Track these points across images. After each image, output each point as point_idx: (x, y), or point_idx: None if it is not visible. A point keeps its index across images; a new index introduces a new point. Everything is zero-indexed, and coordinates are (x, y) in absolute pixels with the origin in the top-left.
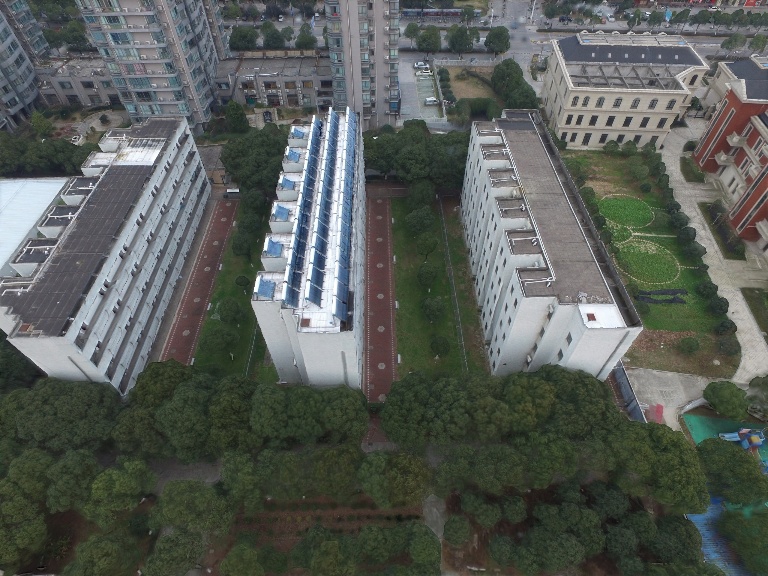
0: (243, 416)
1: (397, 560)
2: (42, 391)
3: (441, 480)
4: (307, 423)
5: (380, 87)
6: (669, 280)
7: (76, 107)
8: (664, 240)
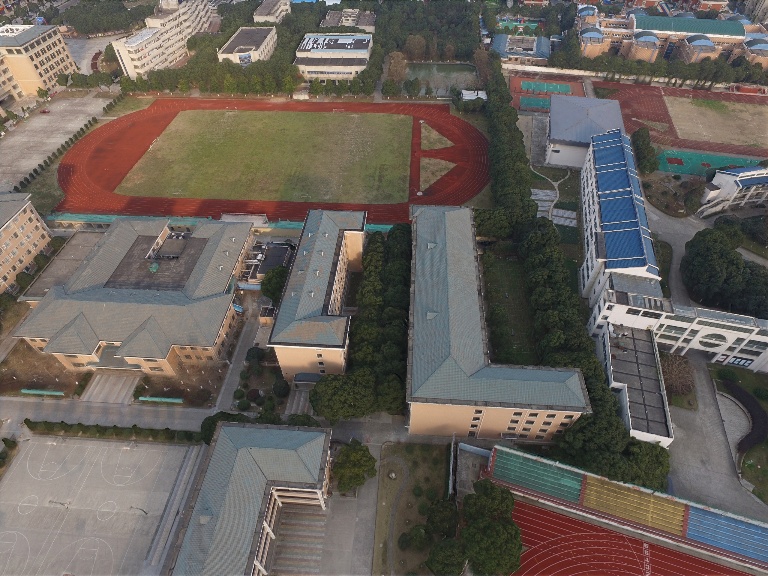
0: (404, 2)
1: None
2: None
3: None
4: (415, 3)
5: None
6: (496, 7)
7: None
8: (499, 3)
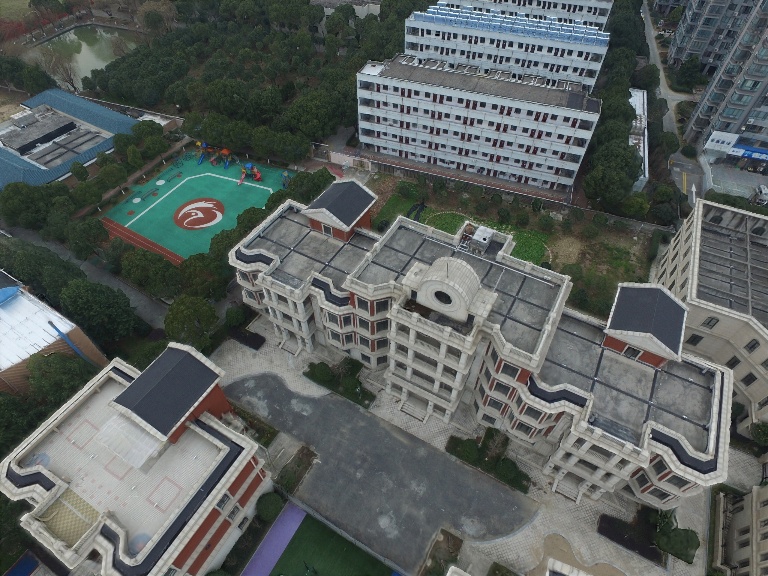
0: None
1: None
2: None
3: None
4: None
5: None
6: None
7: None
8: None
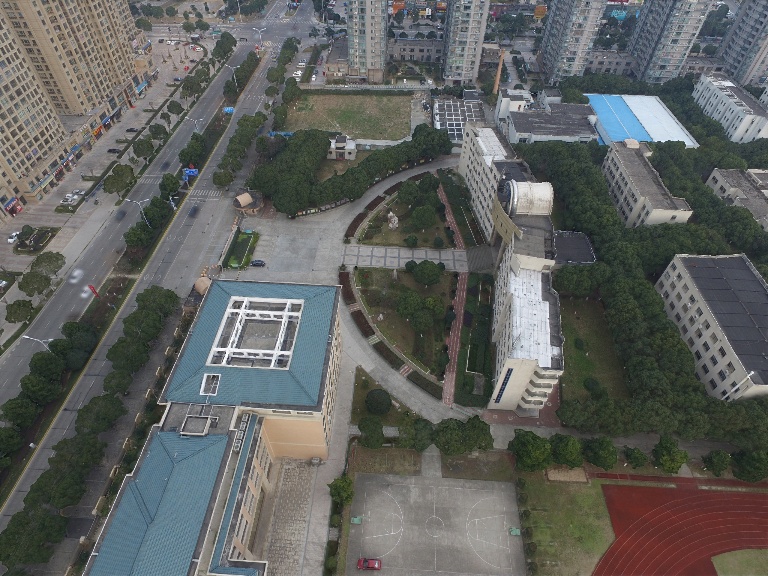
0: None
1: None
2: None
3: None
4: None
5: (761, 70)
6: None
7: (591, 73)
8: None
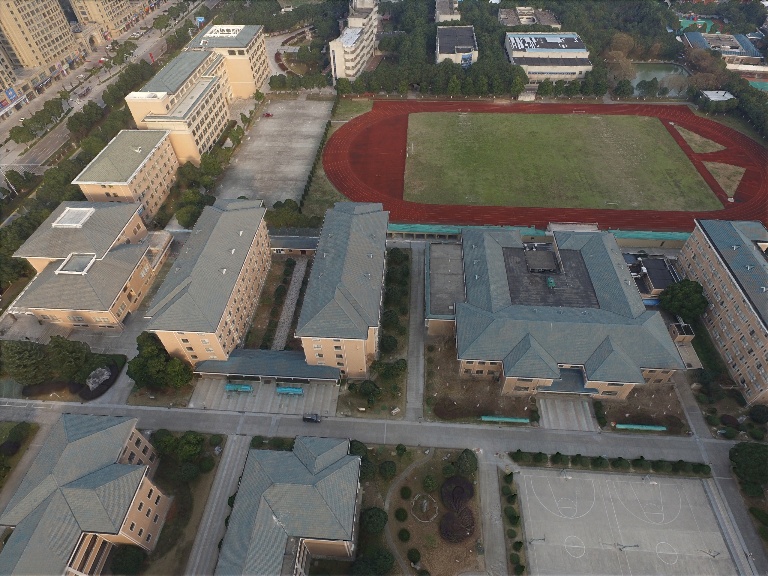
0: None
1: None
2: None
3: (609, 8)
4: None
5: None
6: None
7: None
8: (655, 0)
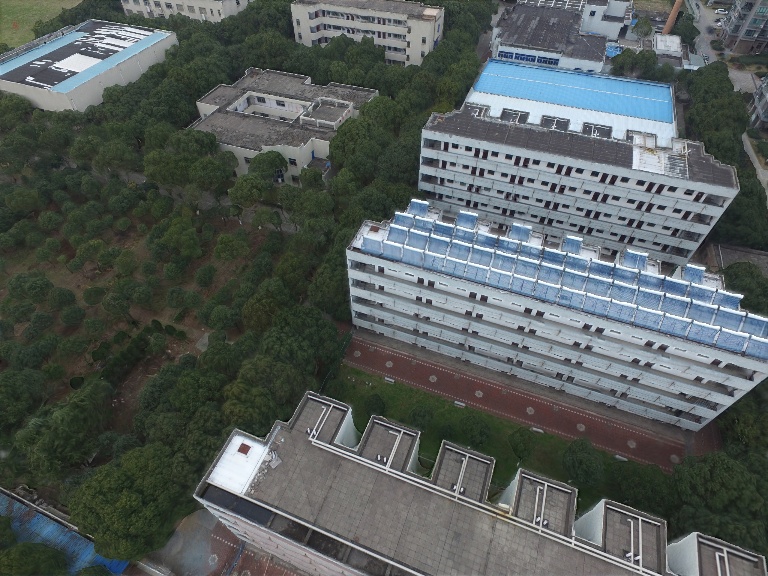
0: None
1: (228, 303)
2: (409, 142)
3: None
4: None
5: None
6: None
7: None
8: None
